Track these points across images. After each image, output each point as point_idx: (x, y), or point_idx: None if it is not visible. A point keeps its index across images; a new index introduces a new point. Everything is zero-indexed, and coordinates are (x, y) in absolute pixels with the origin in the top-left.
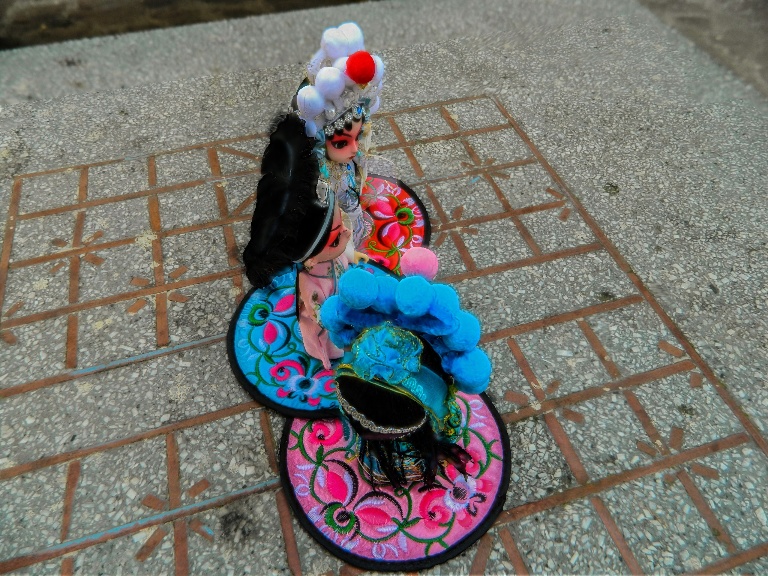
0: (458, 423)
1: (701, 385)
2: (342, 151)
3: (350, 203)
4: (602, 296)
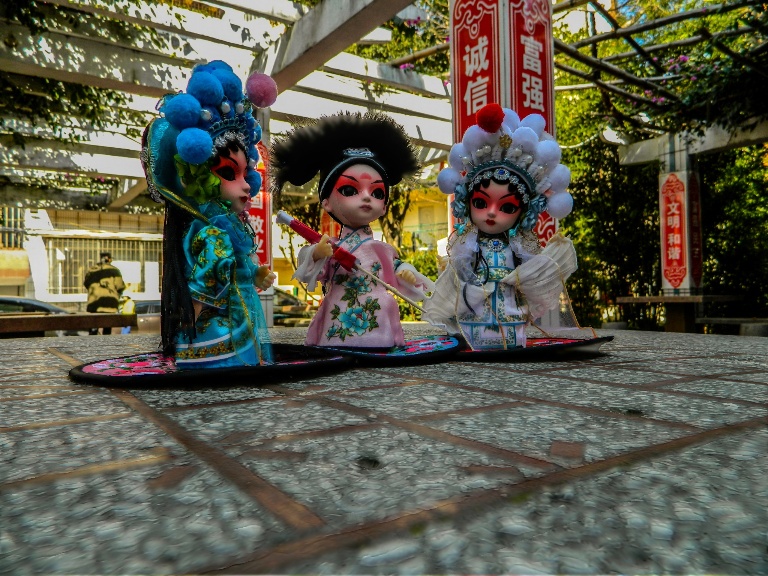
0: (203, 262)
1: (479, 477)
2: (480, 211)
3: (482, 280)
4: (629, 414)
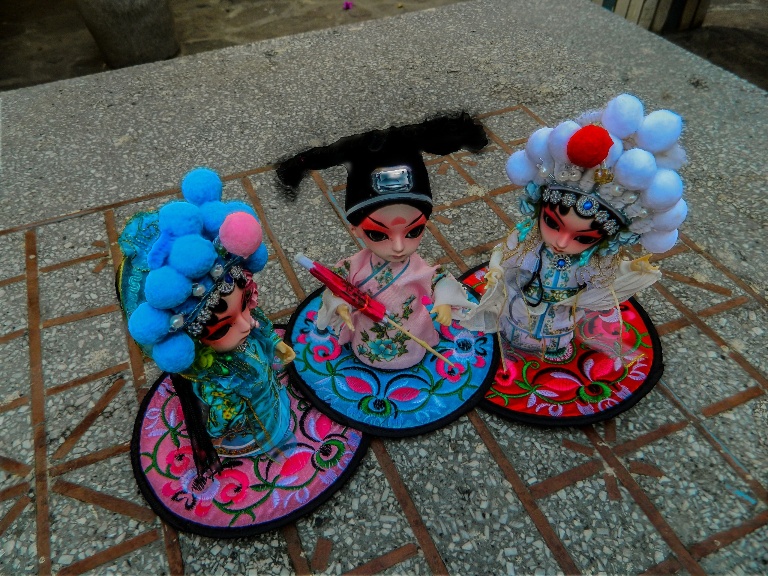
0: (215, 422)
1: None
2: (549, 231)
3: (535, 296)
4: None
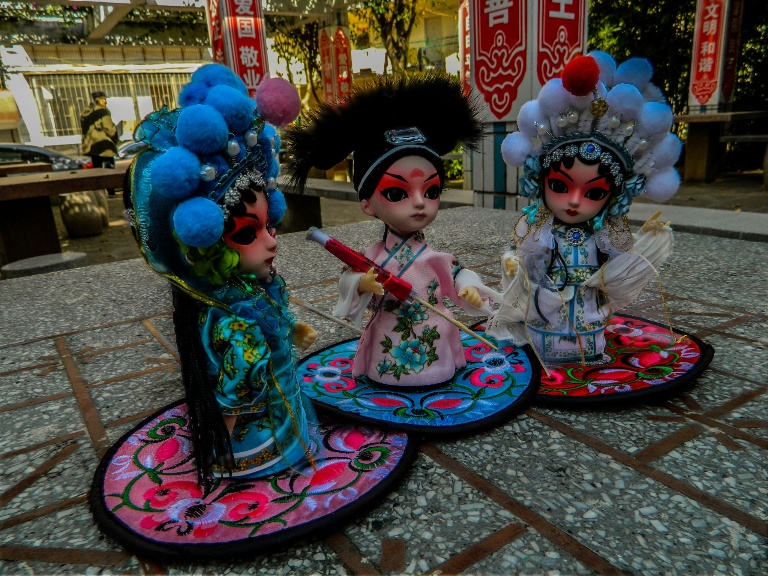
0: (231, 371)
1: None
2: (558, 197)
3: (558, 282)
4: None
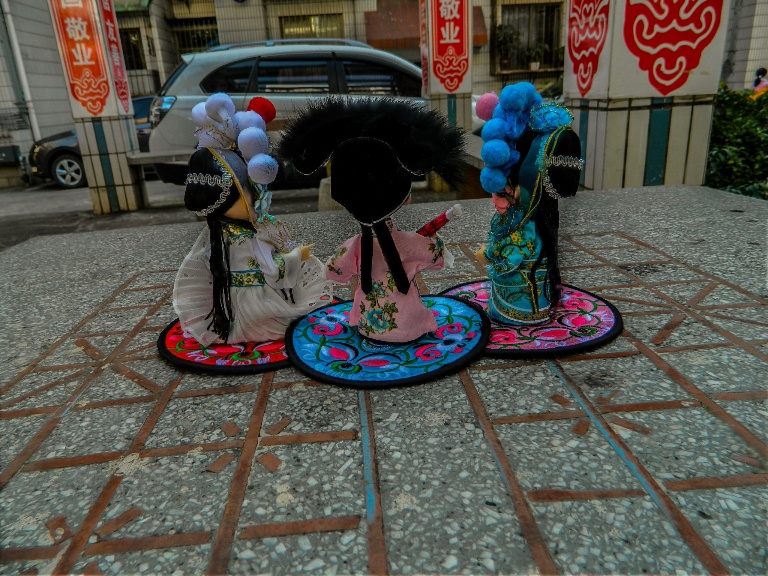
0: None
1: None
2: None
3: None
4: None
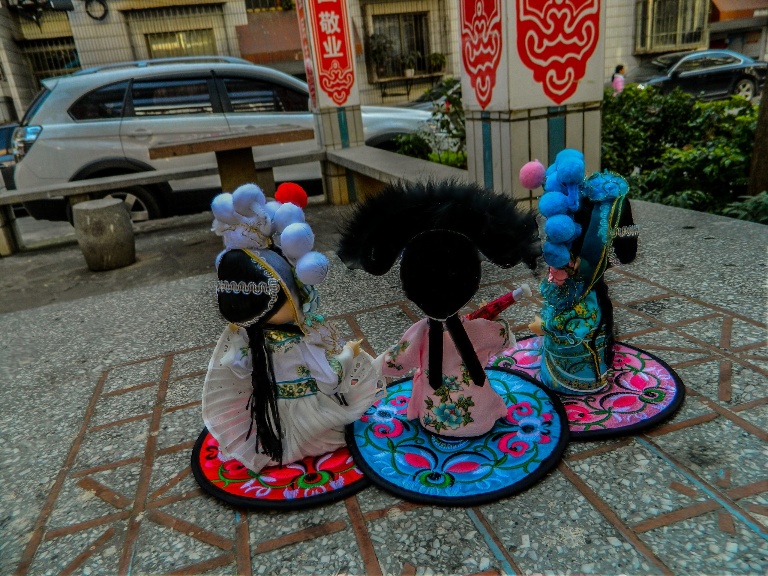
0: None
1: None
2: None
3: None
4: None
